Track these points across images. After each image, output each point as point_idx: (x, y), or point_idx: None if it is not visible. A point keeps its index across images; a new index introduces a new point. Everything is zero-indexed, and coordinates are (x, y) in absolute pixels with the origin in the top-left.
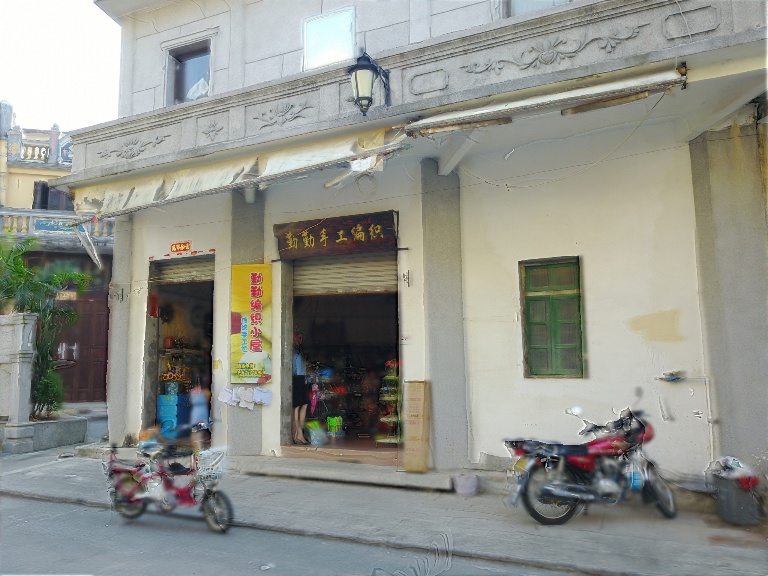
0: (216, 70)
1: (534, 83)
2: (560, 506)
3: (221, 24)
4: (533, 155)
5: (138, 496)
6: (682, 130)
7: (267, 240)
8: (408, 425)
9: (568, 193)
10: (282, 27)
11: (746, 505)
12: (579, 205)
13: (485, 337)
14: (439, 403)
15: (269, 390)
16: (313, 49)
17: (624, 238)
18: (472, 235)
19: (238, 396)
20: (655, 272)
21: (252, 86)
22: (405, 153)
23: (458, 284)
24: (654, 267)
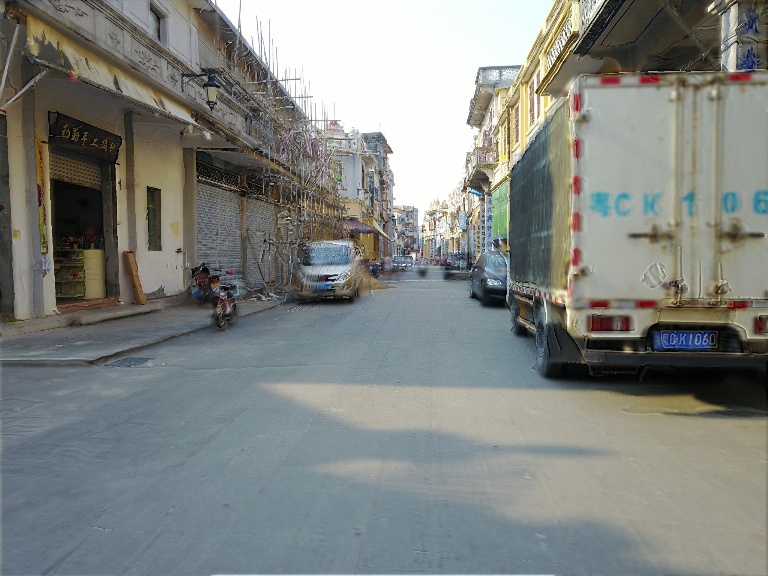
0: None
1: None
2: None
3: None
4: None
5: (227, 312)
6: (186, 143)
7: (37, 119)
8: None
9: None
10: None
11: None
12: None
13: (138, 227)
14: None
15: None
16: None
17: (170, 185)
18: None
19: None
20: None
21: (139, 26)
22: None
23: None
24: None
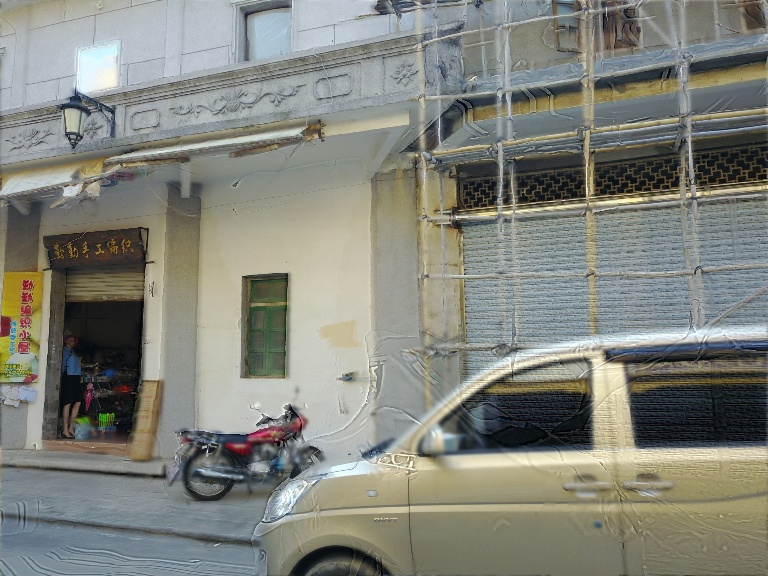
0: (0, 88)
1: (210, 129)
2: (212, 485)
3: (7, 45)
4: (256, 184)
5: None
6: (364, 170)
7: (41, 250)
8: (139, 420)
9: (281, 219)
10: (60, 53)
11: None
12: (290, 229)
13: (213, 342)
14: (169, 400)
15: (34, 389)
16: (85, 76)
17: (321, 259)
18: (208, 252)
19: (3, 394)
20: (341, 289)
21: (4, 111)
22: (127, 180)
23: (194, 295)
24: (341, 284)
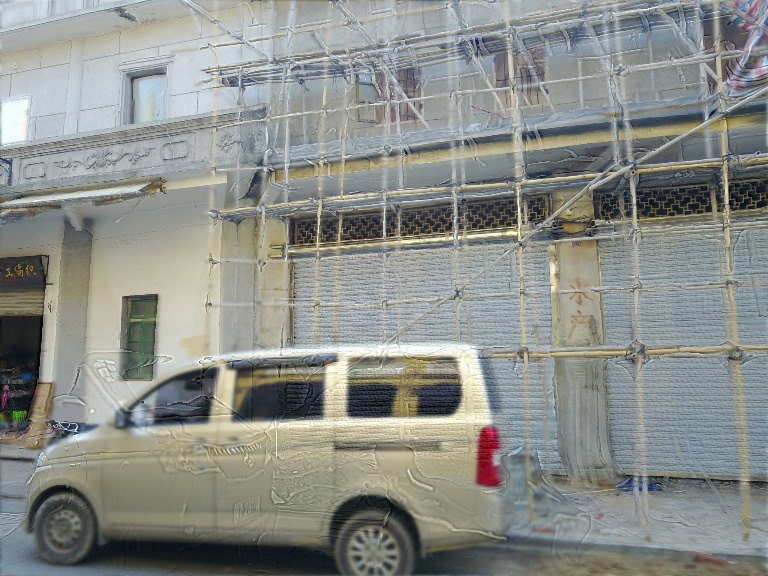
0: None
1: (78, 182)
2: None
3: None
4: (135, 221)
5: None
6: None
7: None
8: None
9: (153, 250)
10: None
11: None
12: (161, 258)
13: None
14: None
15: None
16: (1, 126)
17: (183, 283)
18: (97, 276)
19: None
20: (198, 308)
21: None
22: (21, 219)
23: (84, 312)
24: (198, 305)
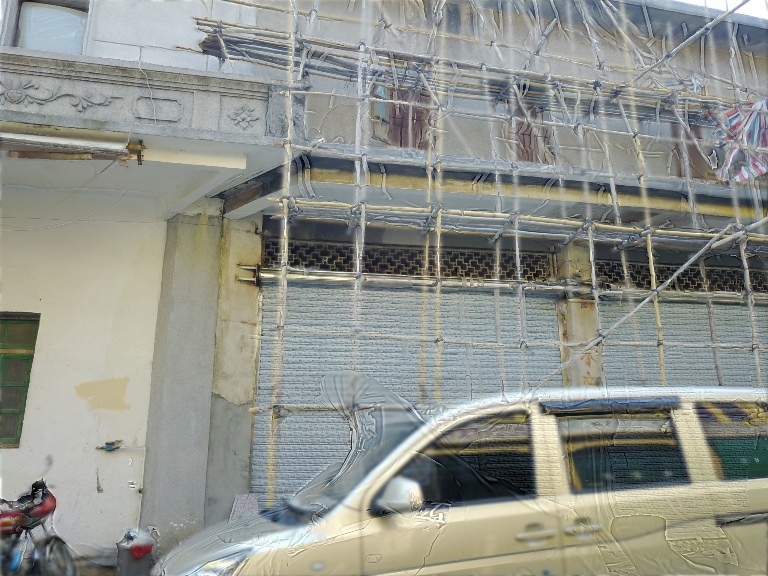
0: None
1: None
2: None
3: None
4: (9, 199)
5: None
6: (161, 208)
7: None
8: None
9: (41, 246)
10: None
11: (146, 575)
12: (51, 260)
13: None
14: None
15: None
16: None
17: (92, 301)
18: None
19: None
20: (116, 339)
21: None
22: None
23: None
24: (116, 334)
